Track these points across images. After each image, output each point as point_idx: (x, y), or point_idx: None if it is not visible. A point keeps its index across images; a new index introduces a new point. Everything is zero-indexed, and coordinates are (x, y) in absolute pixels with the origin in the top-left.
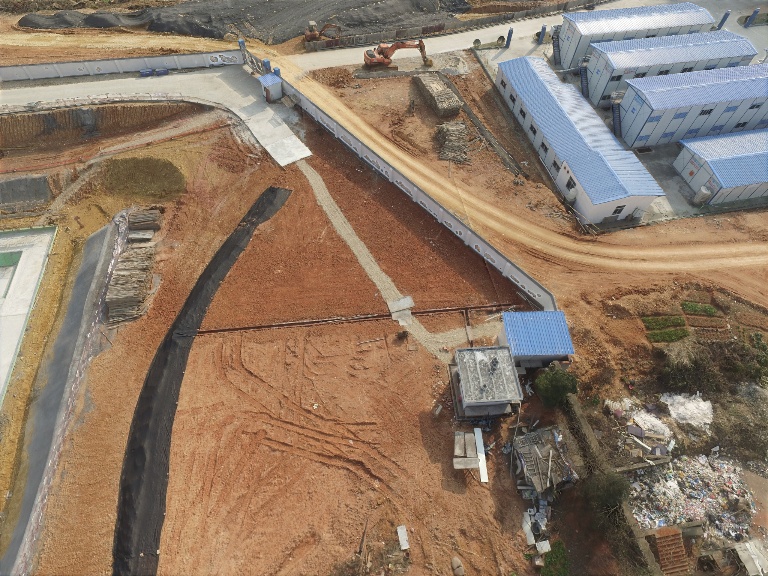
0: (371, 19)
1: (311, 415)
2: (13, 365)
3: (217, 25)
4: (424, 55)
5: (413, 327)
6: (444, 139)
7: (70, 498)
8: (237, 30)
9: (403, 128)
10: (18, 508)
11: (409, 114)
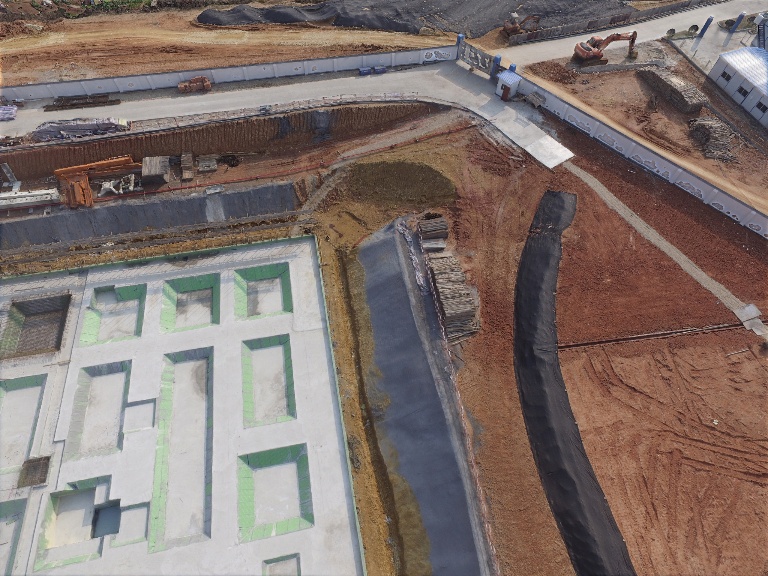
0: (554, 9)
1: (716, 432)
2: (337, 383)
3: (408, 18)
4: (632, 47)
5: None
6: (706, 136)
7: (507, 525)
8: (430, 23)
9: (653, 125)
10: (421, 534)
11: (651, 110)
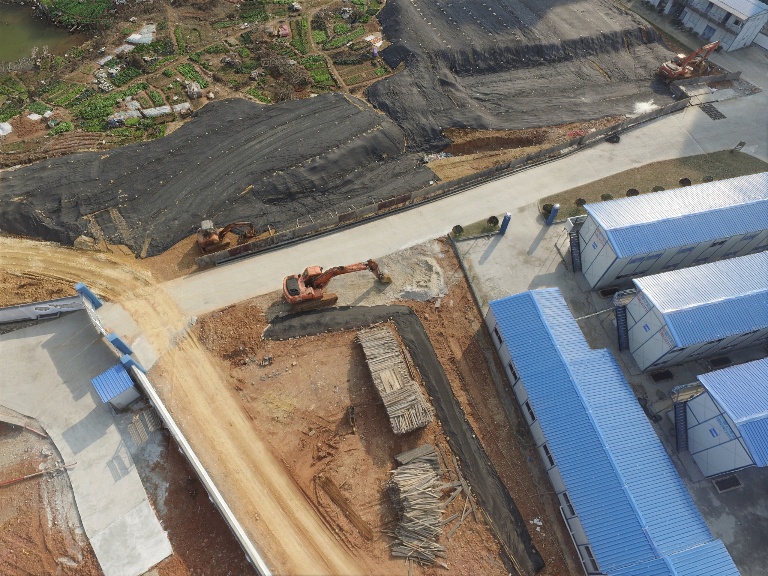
0: (304, 187)
1: None
2: None
3: (67, 218)
4: (377, 272)
5: None
6: (400, 510)
7: None
8: (97, 227)
9: (334, 469)
10: None
11: (346, 429)
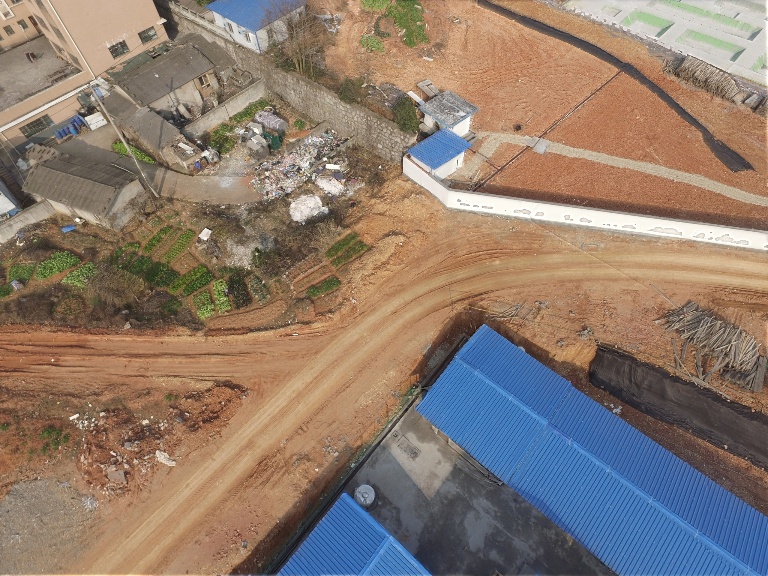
0: None
1: None
2: None
3: None
4: None
5: (518, 139)
6: None
7: None
8: None
9: None
10: None
11: None
